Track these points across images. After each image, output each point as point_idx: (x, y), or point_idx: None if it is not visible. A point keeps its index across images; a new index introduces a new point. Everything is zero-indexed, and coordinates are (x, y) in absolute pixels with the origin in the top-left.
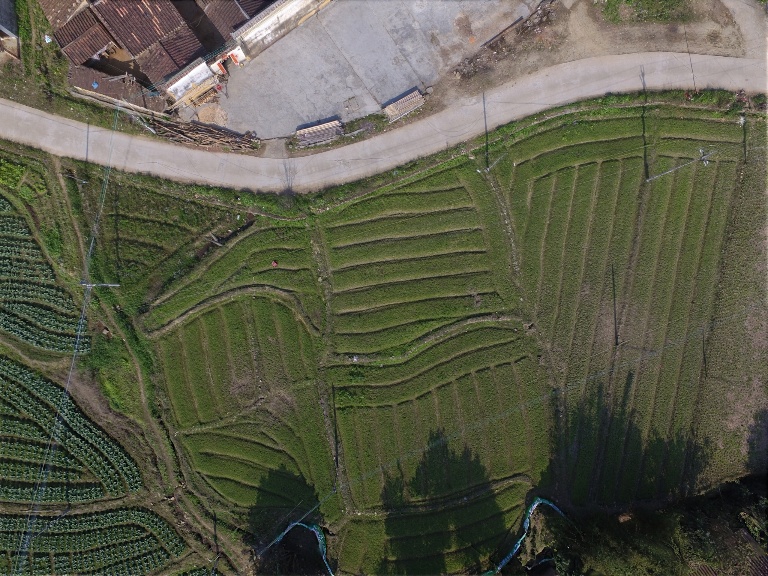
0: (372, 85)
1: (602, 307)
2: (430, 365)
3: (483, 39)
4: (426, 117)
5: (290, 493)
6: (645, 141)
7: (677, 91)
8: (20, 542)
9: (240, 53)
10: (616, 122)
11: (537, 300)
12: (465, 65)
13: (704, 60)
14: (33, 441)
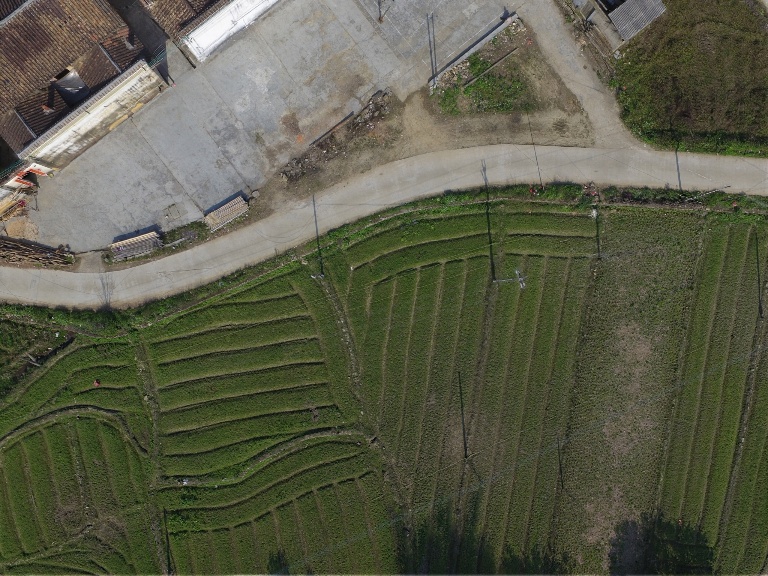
0: (193, 191)
1: (449, 417)
2: (268, 484)
3: (312, 137)
4: (252, 223)
5: None
6: (491, 239)
7: (521, 186)
8: None
9: (42, 167)
10: (459, 220)
11: (379, 412)
12: (292, 166)
13: (550, 151)
14: None
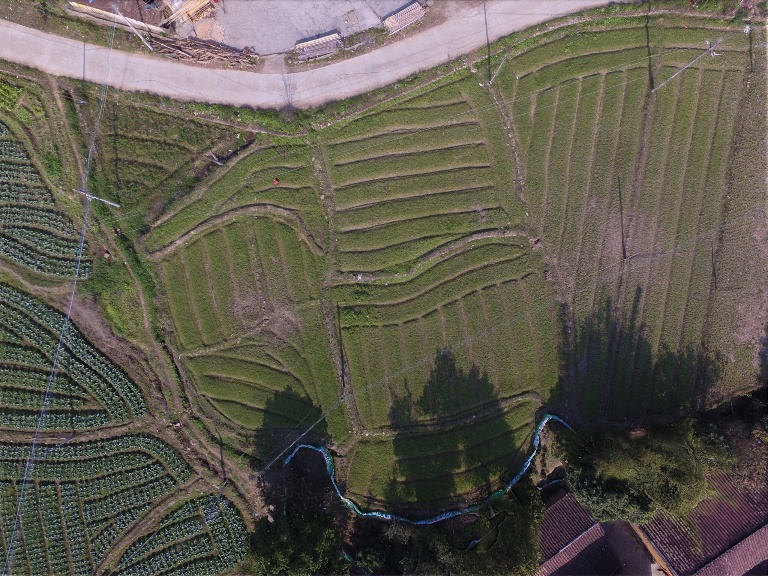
0: None
1: (609, 220)
2: (436, 283)
3: None
4: (427, 30)
5: (297, 414)
6: (649, 51)
7: None
8: (25, 470)
9: None
10: (620, 32)
11: (543, 215)
12: None
13: None
14: (36, 369)
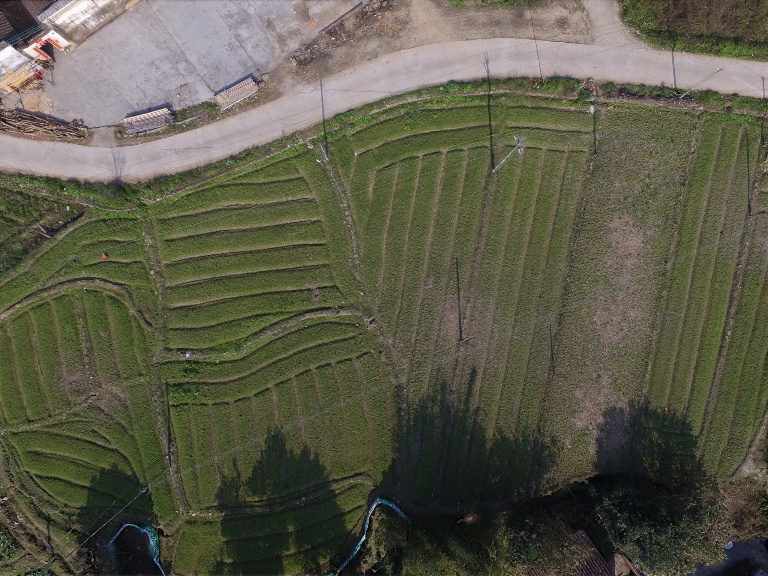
0: (205, 72)
1: (446, 301)
2: (268, 361)
3: (321, 25)
4: (261, 105)
5: (122, 493)
6: (491, 130)
7: (522, 79)
8: None
9: (59, 38)
10: (461, 111)
11: (378, 294)
12: (302, 51)
13: (551, 47)
14: None
